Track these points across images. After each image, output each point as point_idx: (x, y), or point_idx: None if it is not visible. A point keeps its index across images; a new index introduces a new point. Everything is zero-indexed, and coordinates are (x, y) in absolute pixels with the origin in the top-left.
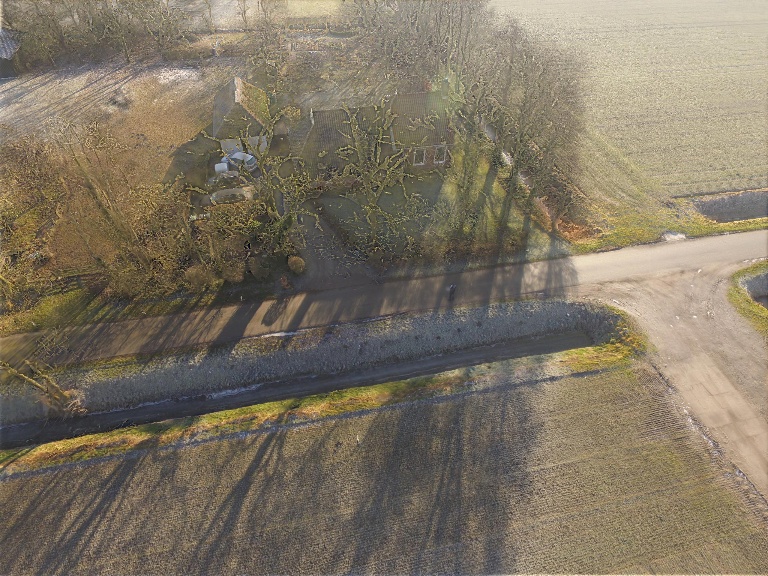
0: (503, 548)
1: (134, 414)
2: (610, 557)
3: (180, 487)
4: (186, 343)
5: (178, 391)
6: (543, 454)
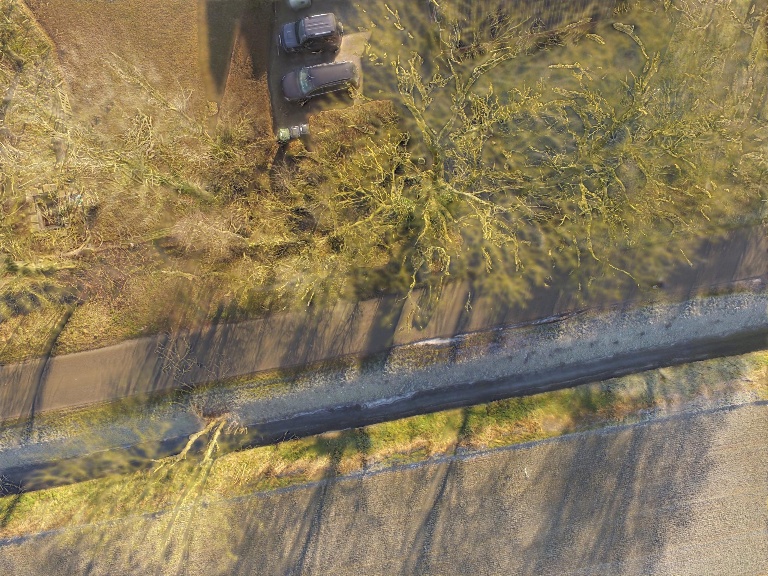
0: (643, 567)
1: (292, 425)
2: (726, 573)
3: (367, 516)
4: (330, 355)
5: (332, 405)
6: (698, 489)
